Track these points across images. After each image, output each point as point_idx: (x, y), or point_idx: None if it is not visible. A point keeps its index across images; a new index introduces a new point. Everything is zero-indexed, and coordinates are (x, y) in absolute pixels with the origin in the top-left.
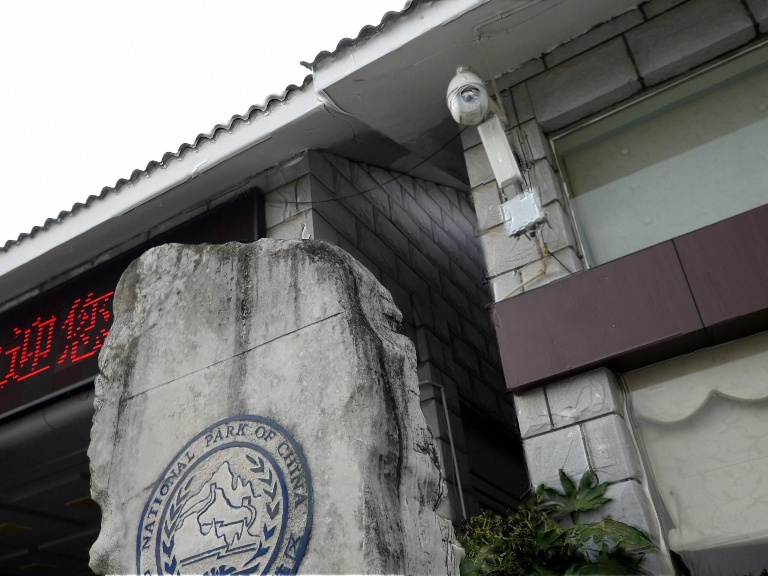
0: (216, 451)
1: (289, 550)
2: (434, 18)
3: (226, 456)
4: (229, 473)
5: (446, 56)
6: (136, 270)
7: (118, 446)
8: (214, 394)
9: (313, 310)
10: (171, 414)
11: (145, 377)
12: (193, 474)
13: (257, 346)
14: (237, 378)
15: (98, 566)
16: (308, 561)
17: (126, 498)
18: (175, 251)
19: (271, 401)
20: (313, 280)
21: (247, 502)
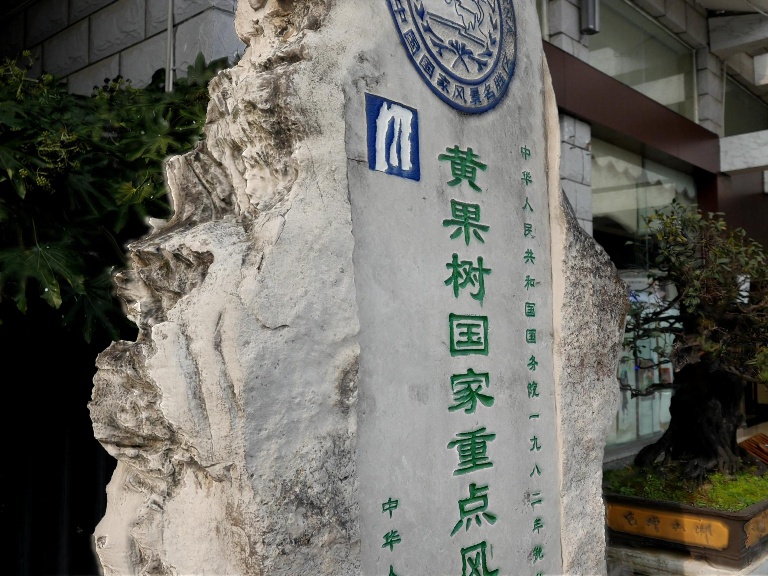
0: None
1: (505, 64)
2: None
3: None
4: None
5: None
6: None
7: None
8: None
9: None
10: None
11: None
12: None
13: None
14: None
15: None
16: (516, 81)
17: None
18: None
19: None
20: None
21: None
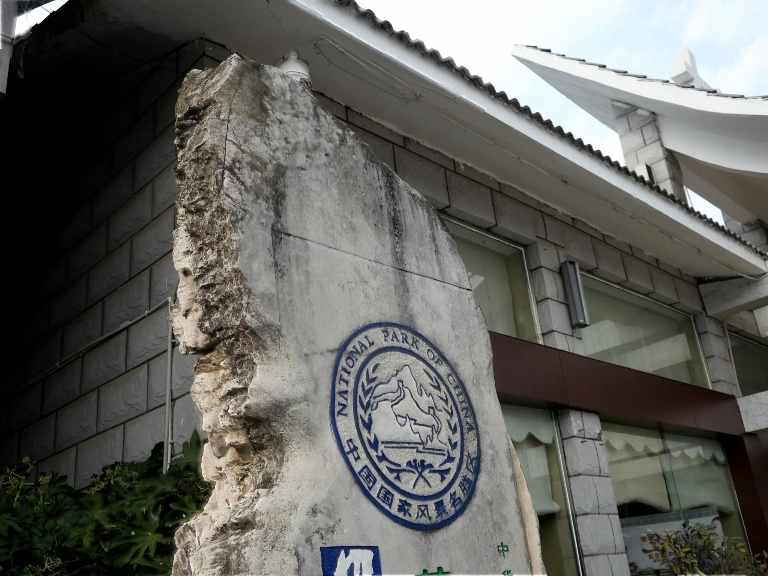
0: (395, 350)
1: None
2: (317, 4)
3: (406, 360)
4: (413, 378)
5: (295, 33)
6: (261, 77)
7: (283, 282)
8: (383, 292)
9: (451, 273)
10: (341, 285)
11: (303, 222)
12: (377, 361)
13: (413, 272)
14: (402, 291)
15: (269, 410)
16: (483, 479)
17: (309, 350)
18: (310, 100)
19: (435, 332)
20: (447, 246)
21: (433, 412)
